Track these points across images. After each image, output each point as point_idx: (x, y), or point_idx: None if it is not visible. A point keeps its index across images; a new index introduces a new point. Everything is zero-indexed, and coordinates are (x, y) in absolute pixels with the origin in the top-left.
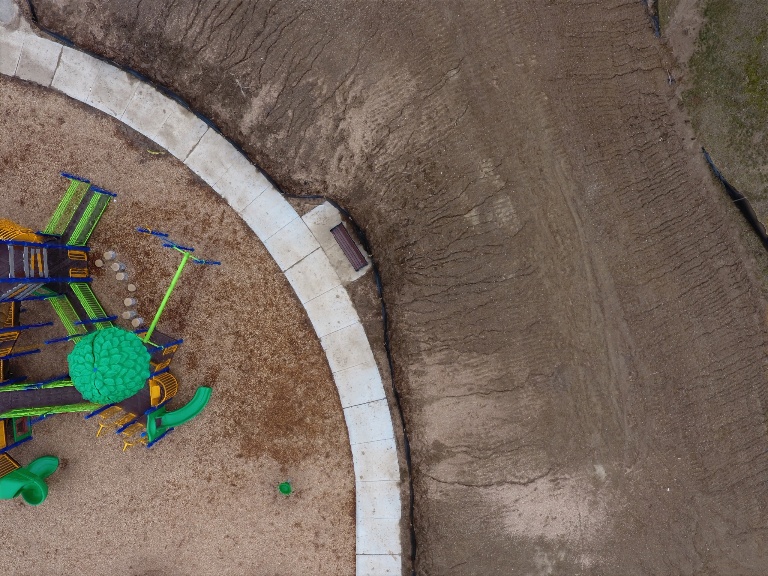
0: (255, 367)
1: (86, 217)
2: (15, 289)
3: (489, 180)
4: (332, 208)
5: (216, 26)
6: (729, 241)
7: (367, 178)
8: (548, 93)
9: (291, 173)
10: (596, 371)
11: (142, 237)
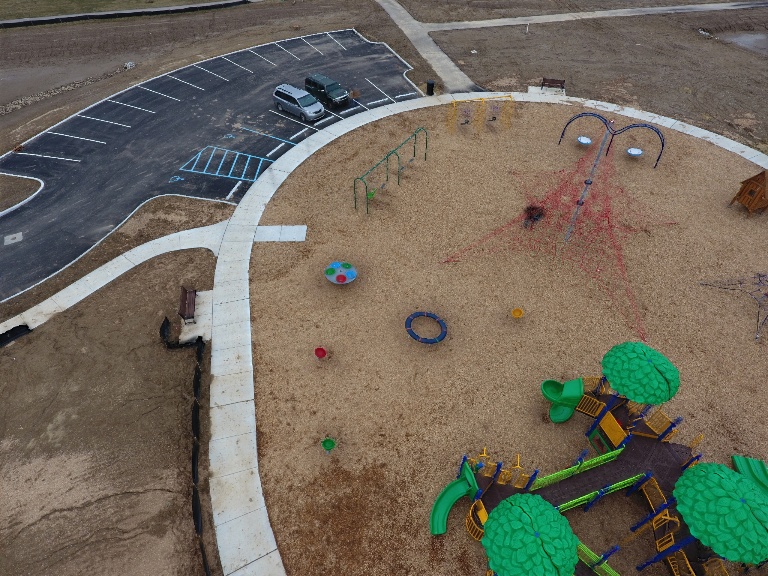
0: None
1: None
2: None
3: None
4: None
5: None
6: None
7: None
8: None
9: None
10: None
11: None
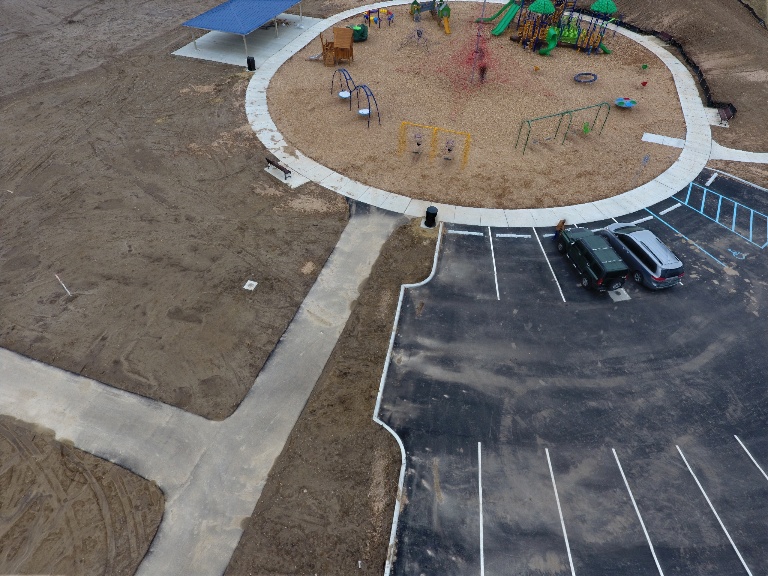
0: None
1: None
2: (572, 1)
3: None
4: (654, 36)
5: (617, 6)
6: None
7: None
8: None
9: None
10: None
11: None
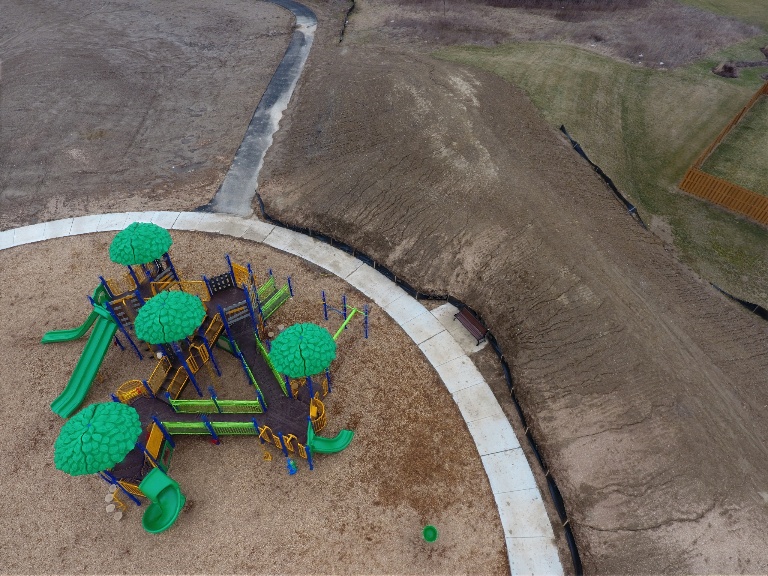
0: (394, 416)
1: (275, 298)
2: (238, 304)
3: (568, 277)
4: (452, 307)
5: (376, 214)
6: (767, 334)
7: (478, 286)
8: (592, 236)
9: (421, 286)
10: (711, 400)
11: (307, 320)
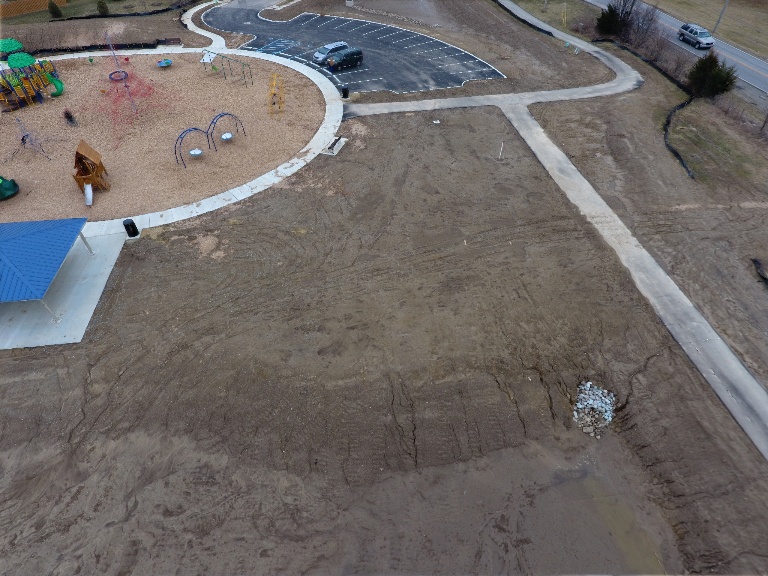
0: None
1: None
2: None
3: None
4: None
5: None
6: None
7: None
8: None
9: None
10: None
11: None
